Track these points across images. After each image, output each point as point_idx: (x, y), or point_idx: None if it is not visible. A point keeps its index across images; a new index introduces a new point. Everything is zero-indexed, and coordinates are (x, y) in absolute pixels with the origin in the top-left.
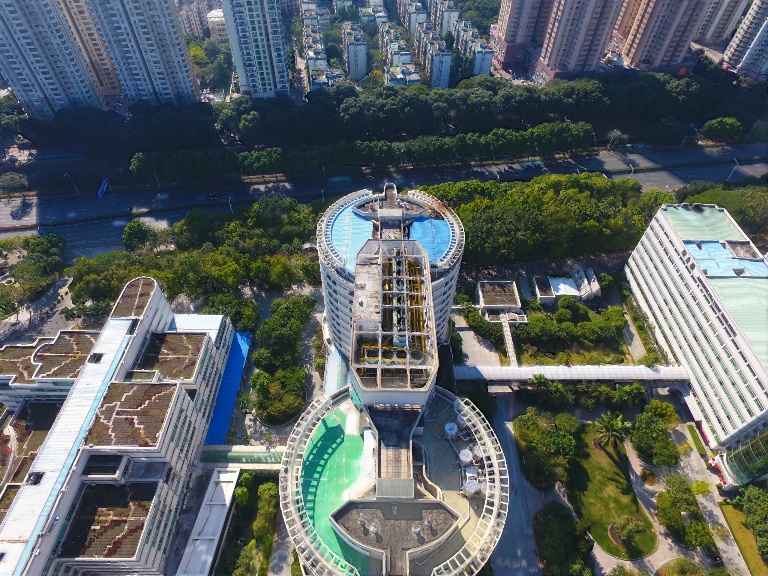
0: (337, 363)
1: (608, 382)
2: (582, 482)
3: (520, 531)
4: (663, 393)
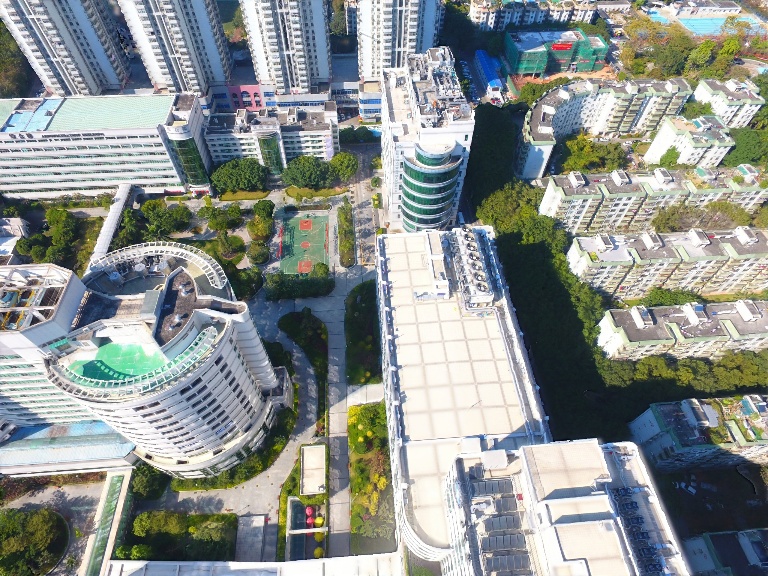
0: (6, 454)
1: (117, 232)
2: None
3: None
4: (138, 207)
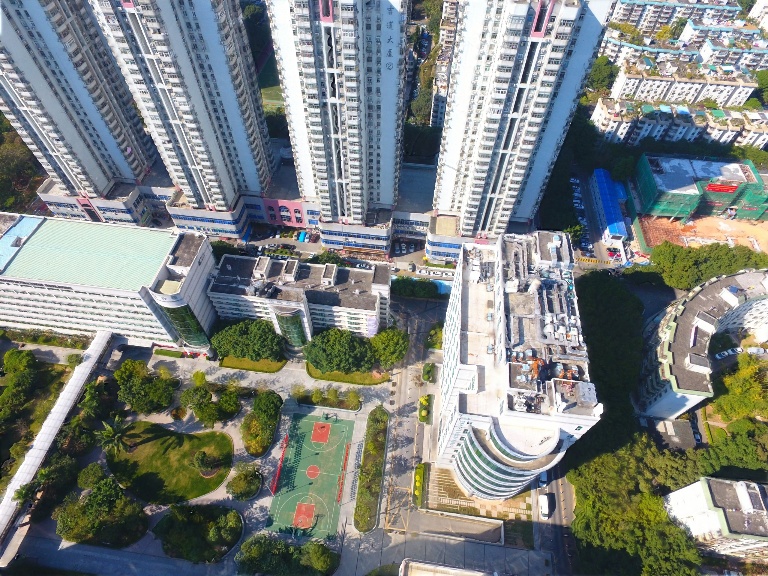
0: None
1: (75, 410)
2: (155, 483)
3: (171, 575)
4: (119, 357)
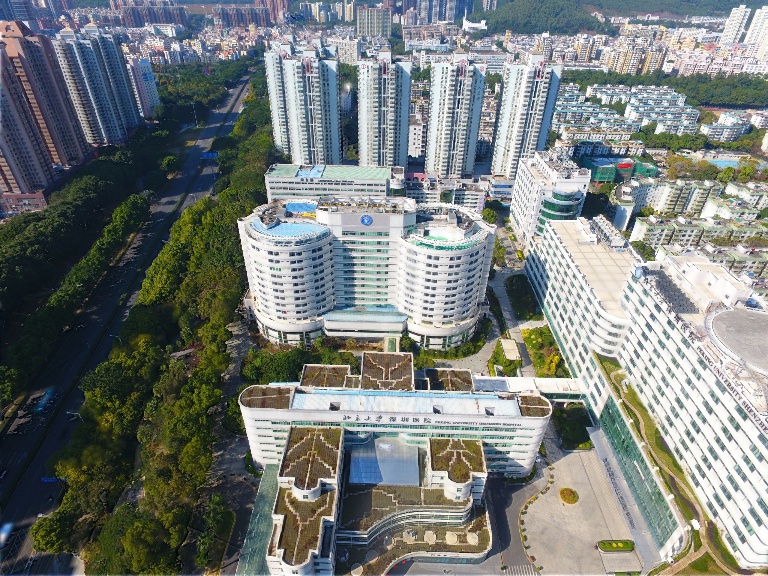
0: (333, 315)
1: None
2: None
3: None
4: None
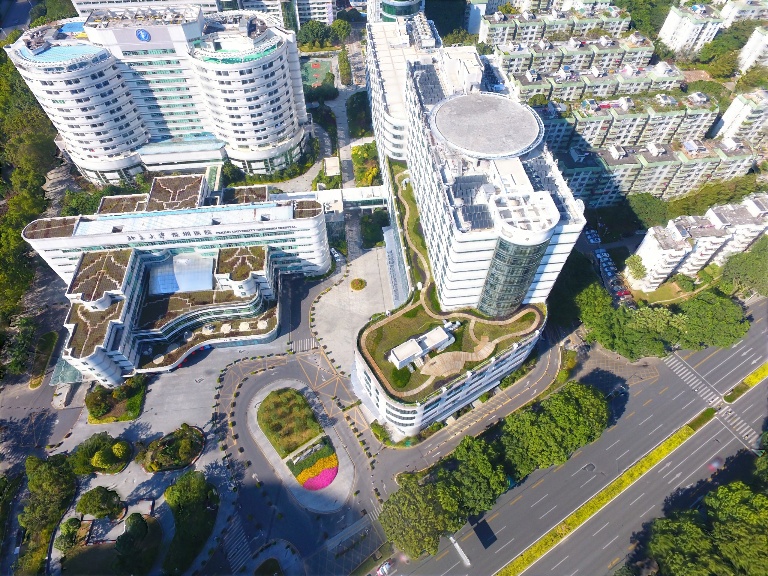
0: (148, 148)
1: None
2: None
3: None
4: None
